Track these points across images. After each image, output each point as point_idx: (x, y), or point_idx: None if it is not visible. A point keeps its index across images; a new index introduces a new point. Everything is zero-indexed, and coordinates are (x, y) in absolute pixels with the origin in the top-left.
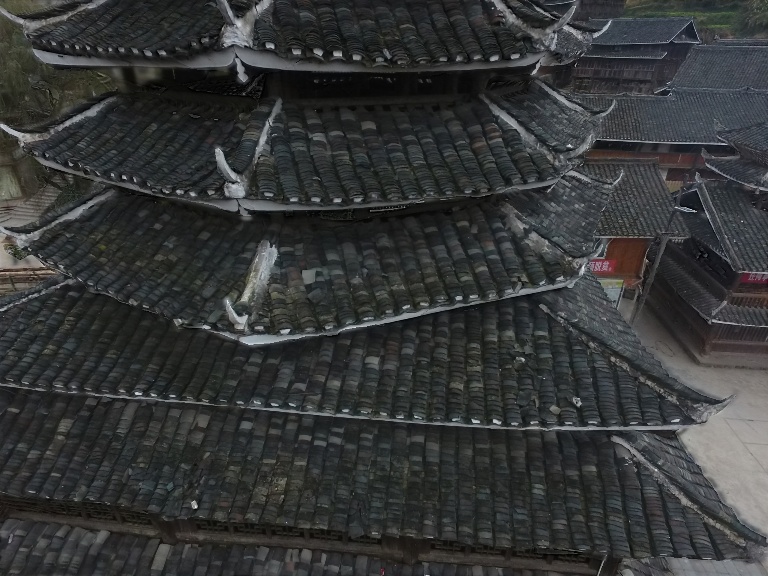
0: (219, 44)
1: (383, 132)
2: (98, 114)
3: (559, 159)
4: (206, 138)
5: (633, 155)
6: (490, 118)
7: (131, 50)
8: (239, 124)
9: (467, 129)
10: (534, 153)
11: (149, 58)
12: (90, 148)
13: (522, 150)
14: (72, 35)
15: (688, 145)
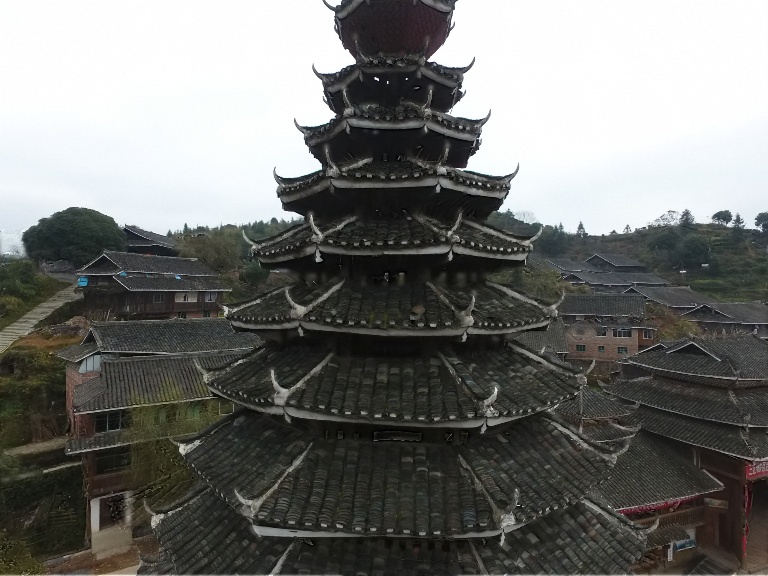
0: (498, 527)
1: (544, 541)
2: (285, 568)
3: (641, 535)
4: None
5: None
6: (583, 508)
7: (399, 530)
8: (470, 569)
9: (577, 520)
10: (623, 532)
11: (421, 536)
12: None
13: (618, 532)
14: (301, 508)
15: None
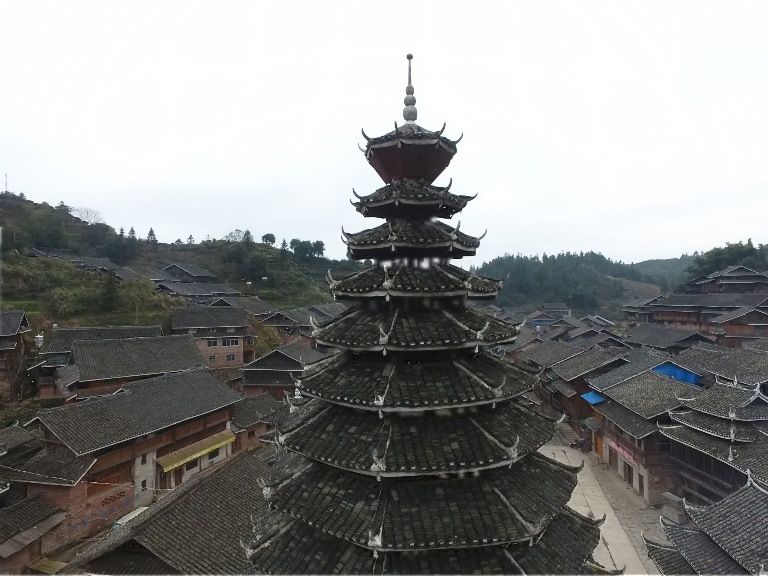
0: None
1: None
2: None
3: None
4: (557, 528)
5: (132, 448)
6: None
7: None
8: None
9: None
10: None
11: None
12: (555, 575)
13: None
14: None
15: (171, 426)
